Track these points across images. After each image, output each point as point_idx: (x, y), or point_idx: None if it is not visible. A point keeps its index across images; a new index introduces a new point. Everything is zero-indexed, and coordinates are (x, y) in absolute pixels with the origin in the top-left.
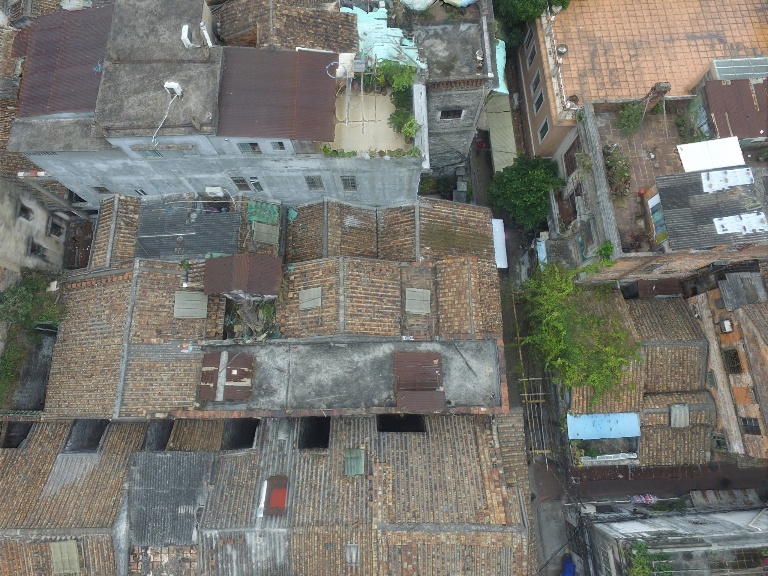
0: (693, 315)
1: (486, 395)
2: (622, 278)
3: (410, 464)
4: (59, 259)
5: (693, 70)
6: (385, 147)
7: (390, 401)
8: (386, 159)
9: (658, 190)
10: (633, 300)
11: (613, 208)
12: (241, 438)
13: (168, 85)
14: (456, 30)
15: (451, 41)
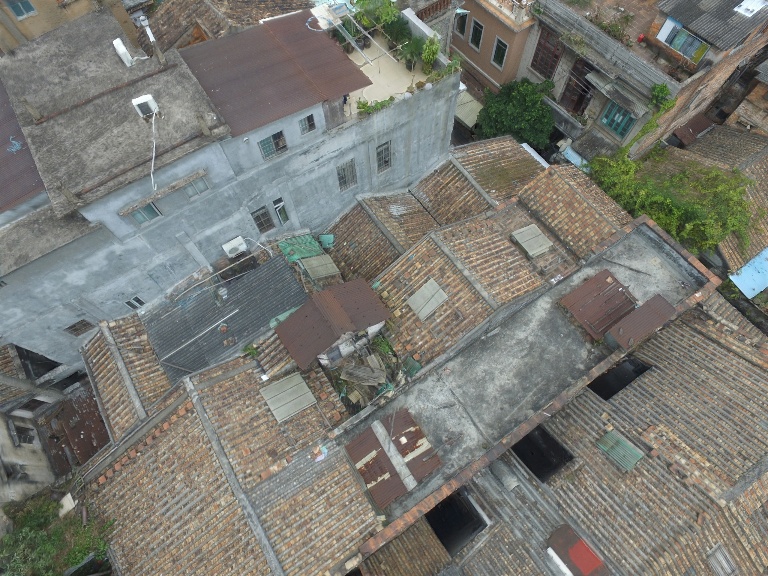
0: (743, 130)
1: (676, 287)
2: (663, 134)
3: (675, 408)
4: (47, 473)
5: None
6: None
7: (595, 356)
8: (428, 88)
9: (668, 14)
10: (684, 149)
11: (638, 55)
12: (442, 536)
13: (138, 101)
14: None
15: None
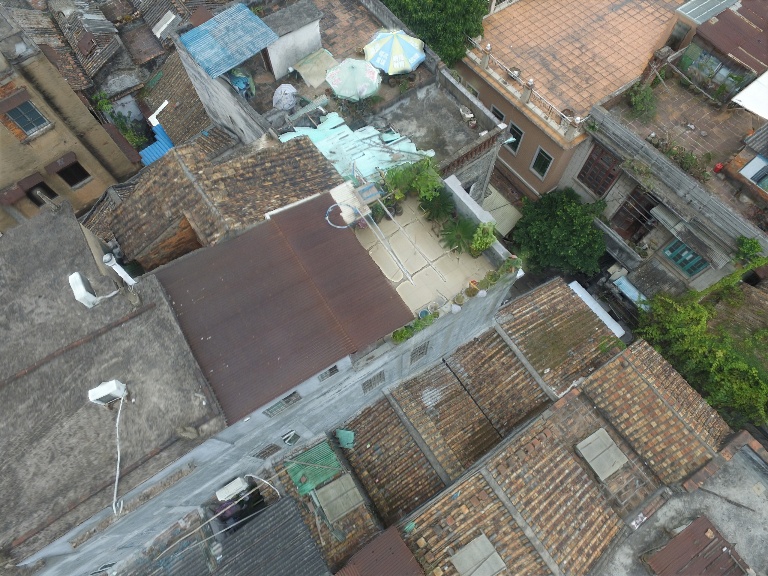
0: None
1: None
2: None
3: None
4: None
5: (643, 34)
6: (453, 280)
7: None
8: (481, 296)
9: (759, 153)
10: (761, 285)
11: (720, 199)
12: None
13: (96, 394)
14: (415, 101)
15: (418, 115)
